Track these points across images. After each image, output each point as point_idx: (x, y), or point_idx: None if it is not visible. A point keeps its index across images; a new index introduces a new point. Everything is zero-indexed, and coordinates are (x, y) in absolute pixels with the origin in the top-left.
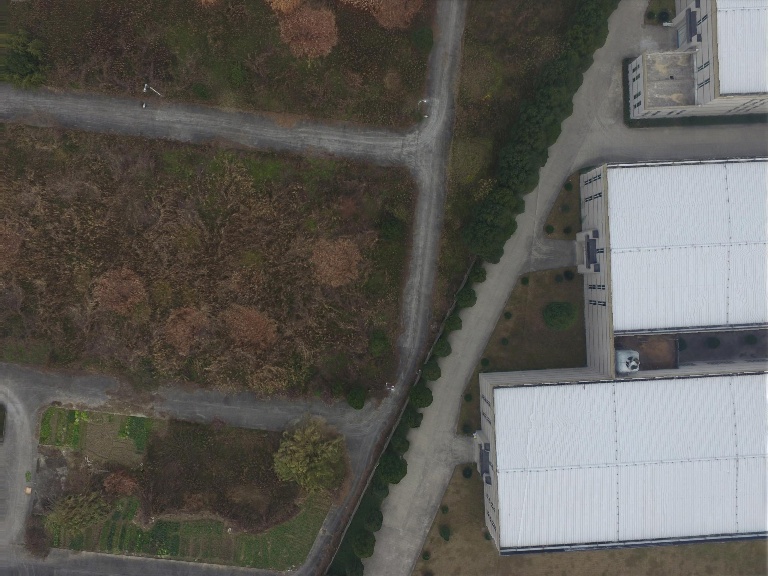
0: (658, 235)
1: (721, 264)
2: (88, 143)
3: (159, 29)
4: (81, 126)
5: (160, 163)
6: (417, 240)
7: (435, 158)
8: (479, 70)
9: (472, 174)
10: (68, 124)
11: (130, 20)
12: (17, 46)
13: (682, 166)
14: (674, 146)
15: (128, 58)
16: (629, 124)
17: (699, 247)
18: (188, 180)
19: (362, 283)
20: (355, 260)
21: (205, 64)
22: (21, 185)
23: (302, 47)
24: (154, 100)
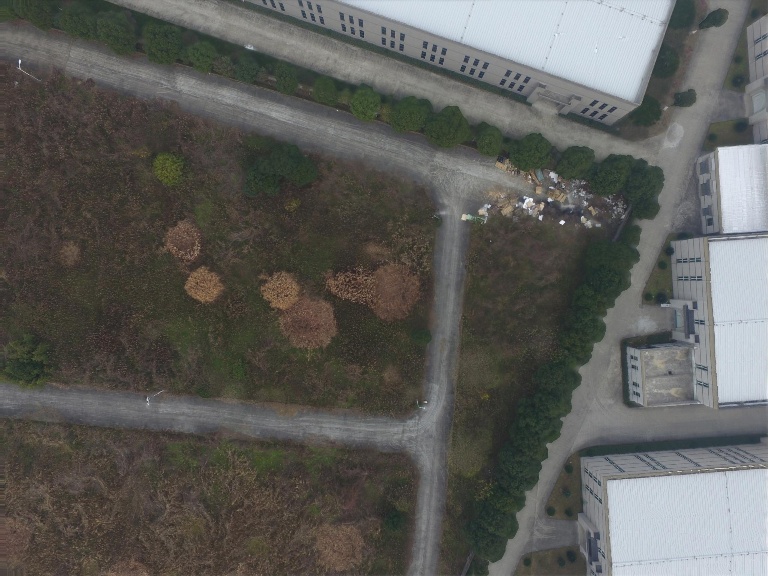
0: (659, 547)
1: (723, 563)
2: (94, 439)
3: (160, 326)
4: (86, 420)
5: (164, 455)
6: (419, 523)
7: (436, 443)
8: (477, 354)
9: (473, 471)
10: (74, 418)
11: (132, 321)
12: (22, 355)
13: (682, 476)
14: (674, 424)
15: (131, 359)
16: (628, 405)
17: (700, 558)
18: (192, 471)
19: (366, 571)
20: (358, 546)
21: (206, 362)
22: (29, 482)
23: (302, 341)
24: (157, 394)
